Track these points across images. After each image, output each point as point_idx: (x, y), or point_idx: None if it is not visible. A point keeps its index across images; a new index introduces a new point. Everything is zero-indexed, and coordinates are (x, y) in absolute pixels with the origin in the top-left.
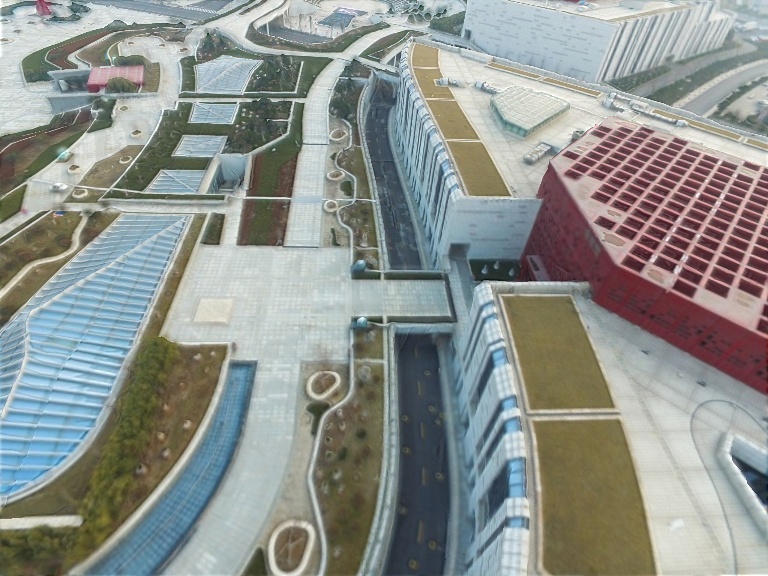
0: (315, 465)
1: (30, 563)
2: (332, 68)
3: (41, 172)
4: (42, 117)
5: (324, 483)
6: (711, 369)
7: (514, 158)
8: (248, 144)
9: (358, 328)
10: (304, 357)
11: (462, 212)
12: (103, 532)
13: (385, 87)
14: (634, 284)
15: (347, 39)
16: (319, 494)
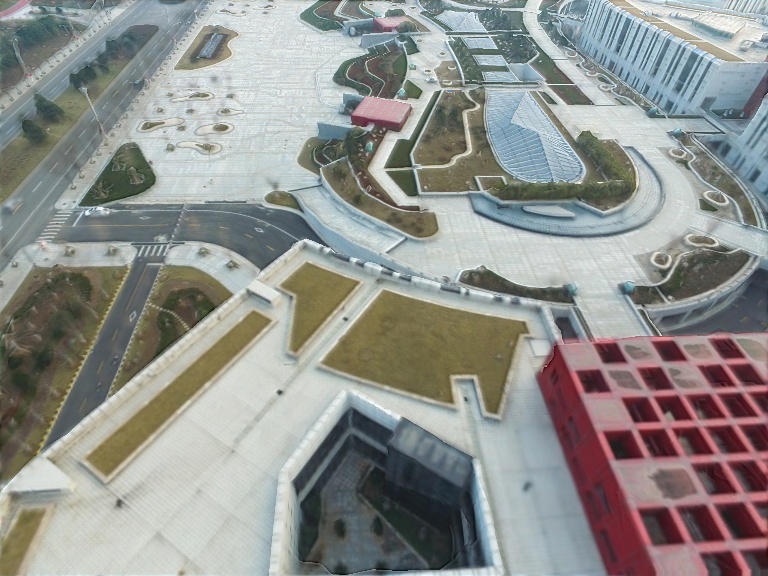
0: (702, 177)
1: None
2: (528, 17)
3: (408, 74)
4: (358, 50)
5: None
6: None
7: (732, 49)
8: (522, 58)
9: (677, 134)
10: (656, 145)
11: (722, 73)
12: (635, 186)
13: (566, 31)
14: None
15: None
16: (713, 185)
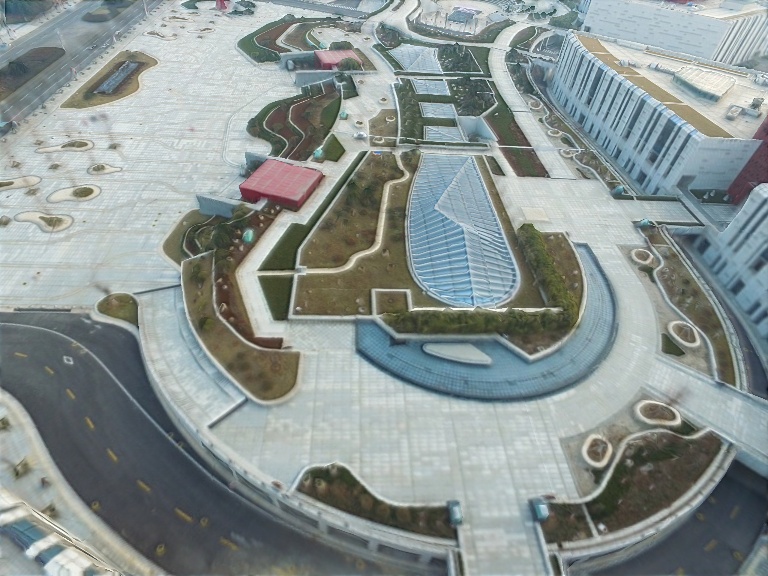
0: (669, 296)
1: None
2: (494, 55)
3: (335, 126)
4: (290, 89)
5: (684, 303)
6: None
7: (717, 116)
8: (476, 109)
9: (643, 226)
10: (616, 242)
11: (702, 149)
12: (578, 317)
13: (537, 72)
14: None
15: (491, 32)
16: (681, 310)
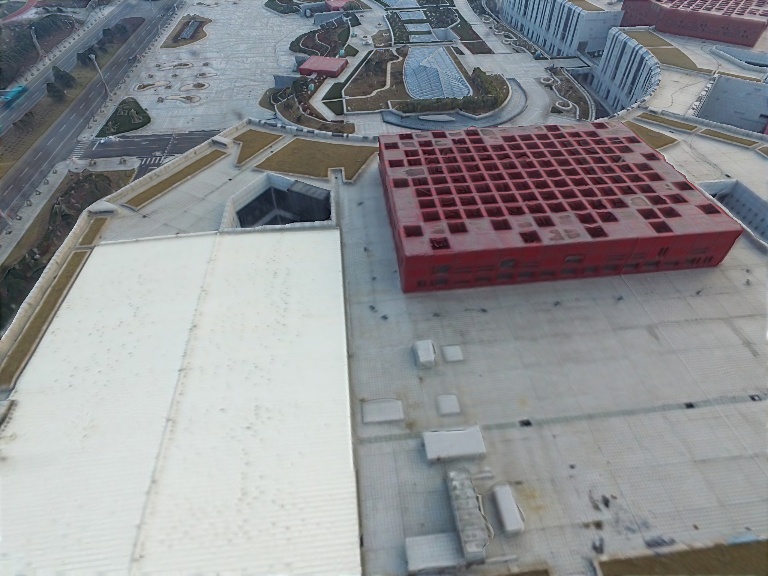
0: None
1: (483, 107)
2: None
3: (349, 40)
4: (312, 27)
5: None
6: (707, 40)
7: (602, 4)
8: (444, 24)
9: (551, 68)
10: (533, 77)
11: (587, 21)
12: None
13: (491, 4)
14: (675, 14)
15: None
16: None
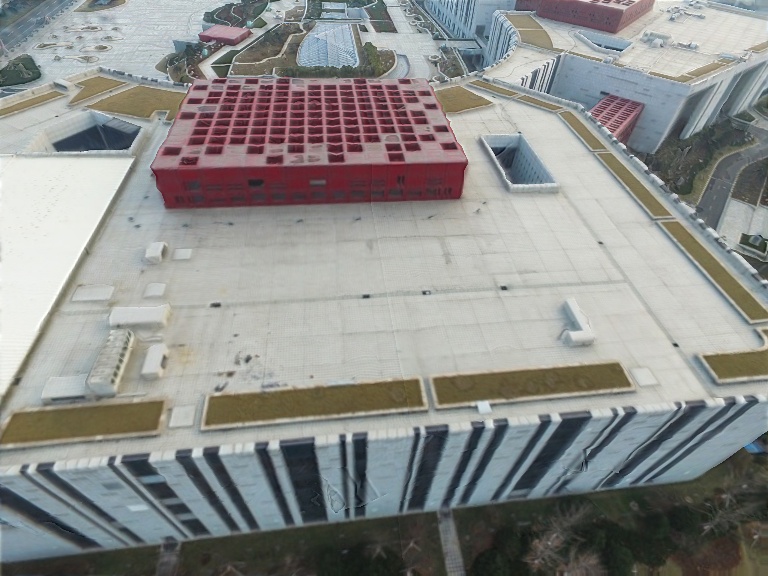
0: None
1: (361, 77)
2: None
3: (262, 14)
4: (234, 1)
5: None
6: None
7: None
8: (360, 4)
9: (443, 48)
10: (424, 54)
11: (482, 5)
12: (381, 70)
13: None
14: None
15: None
16: (444, 73)
